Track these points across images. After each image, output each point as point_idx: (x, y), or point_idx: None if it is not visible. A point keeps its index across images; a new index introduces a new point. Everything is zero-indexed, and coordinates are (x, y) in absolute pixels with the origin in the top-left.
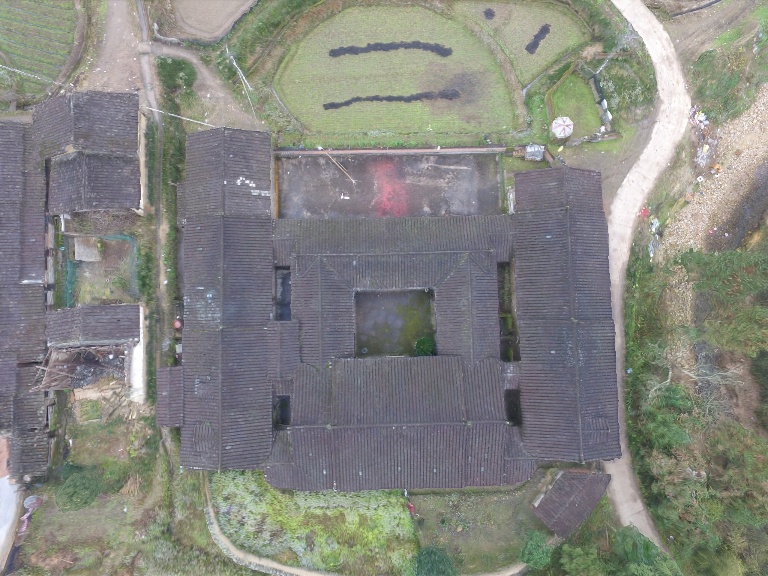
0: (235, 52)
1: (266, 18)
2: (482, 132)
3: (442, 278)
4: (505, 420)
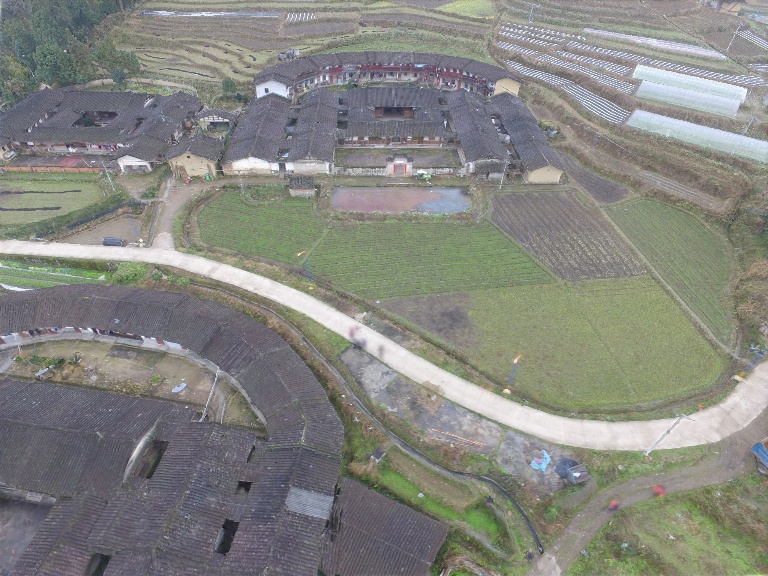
0: (112, 197)
1: (84, 210)
2: (2, 180)
3: (63, 126)
4: (66, 91)
